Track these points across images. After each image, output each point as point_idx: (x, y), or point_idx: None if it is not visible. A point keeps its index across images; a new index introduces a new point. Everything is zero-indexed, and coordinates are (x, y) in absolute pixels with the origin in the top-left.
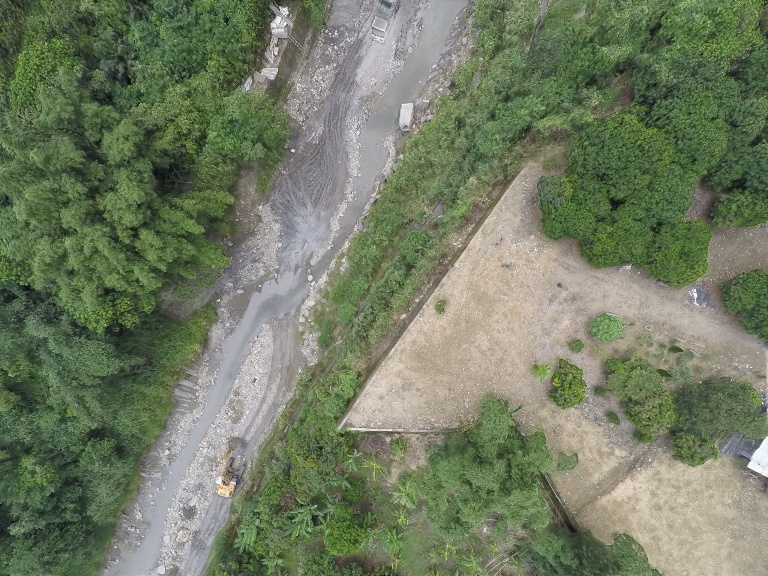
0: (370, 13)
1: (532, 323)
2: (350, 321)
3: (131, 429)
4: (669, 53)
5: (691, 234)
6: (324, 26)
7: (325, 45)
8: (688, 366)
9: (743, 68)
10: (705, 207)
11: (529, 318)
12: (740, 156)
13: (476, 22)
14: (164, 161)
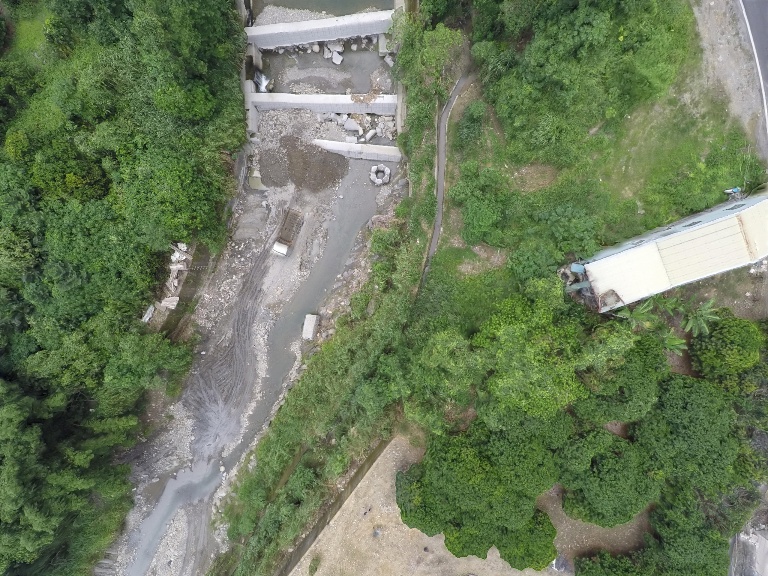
0: (276, 225)
1: None
2: (250, 533)
3: None
4: (495, 410)
5: (533, 539)
6: (231, 239)
7: (232, 258)
8: None
9: (575, 405)
10: (561, 487)
11: (399, 575)
12: (576, 476)
13: (372, 251)
14: (61, 406)
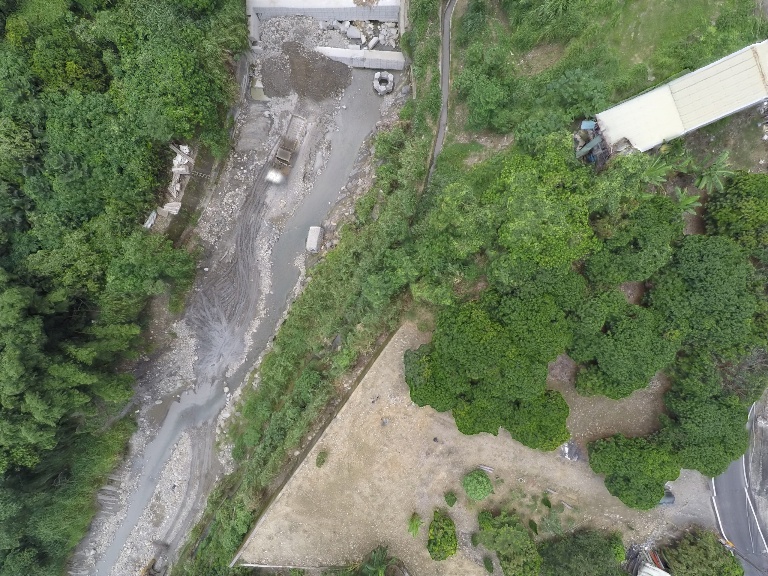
0: (279, 137)
1: (411, 473)
2: (255, 445)
3: (53, 537)
4: (506, 262)
5: (546, 412)
6: (233, 151)
7: (234, 169)
8: (560, 516)
9: (588, 264)
10: (573, 370)
11: (408, 468)
12: (589, 343)
13: None
14: (62, 306)
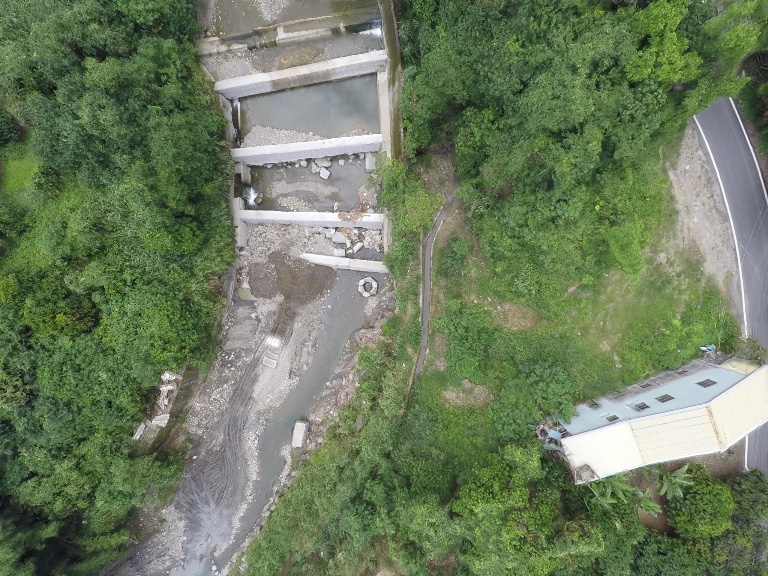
0: (266, 335)
1: None
2: None
3: None
4: None
5: None
6: (221, 349)
7: (222, 368)
8: None
9: None
10: None
11: None
12: None
13: None
14: None
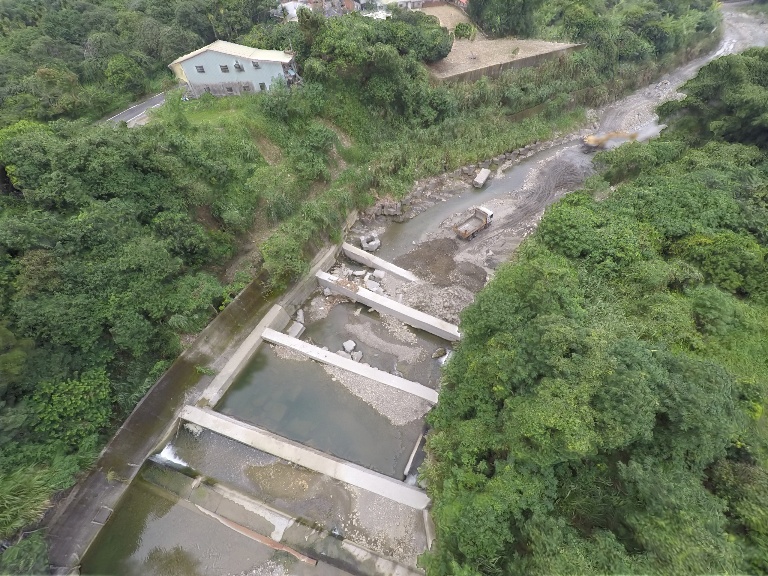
0: (486, 241)
1: None
2: None
3: None
4: None
5: None
6: None
7: None
8: None
9: None
10: None
11: None
12: None
13: None
14: None
